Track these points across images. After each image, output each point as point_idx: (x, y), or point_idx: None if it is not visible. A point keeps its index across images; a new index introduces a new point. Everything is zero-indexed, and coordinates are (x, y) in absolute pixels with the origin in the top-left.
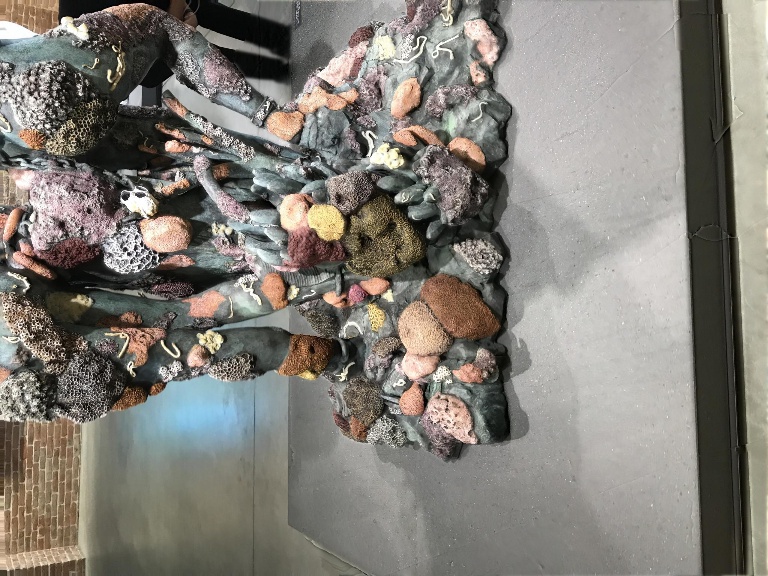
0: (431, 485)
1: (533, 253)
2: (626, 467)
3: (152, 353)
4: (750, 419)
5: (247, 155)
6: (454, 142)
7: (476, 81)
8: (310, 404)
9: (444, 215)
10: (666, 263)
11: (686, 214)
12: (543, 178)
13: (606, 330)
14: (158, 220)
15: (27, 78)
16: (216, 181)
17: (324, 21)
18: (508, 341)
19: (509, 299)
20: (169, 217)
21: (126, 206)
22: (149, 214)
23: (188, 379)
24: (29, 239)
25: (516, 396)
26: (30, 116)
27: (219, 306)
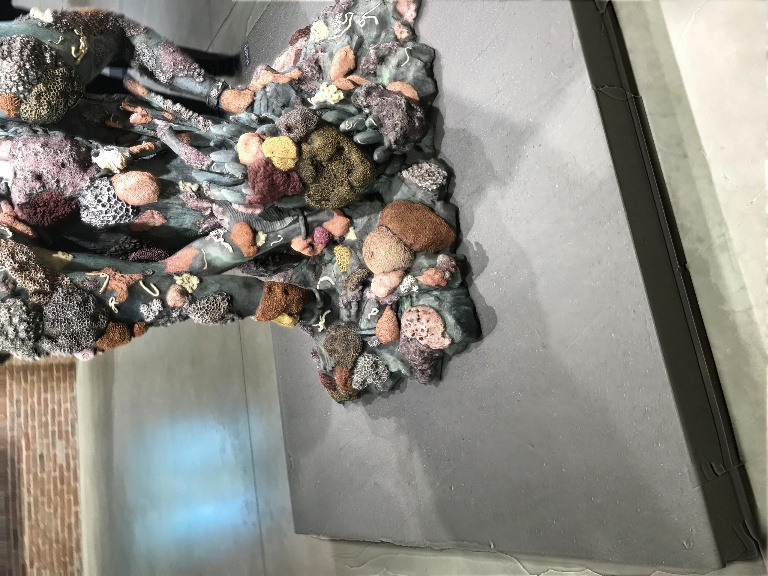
0: (421, 419)
1: (473, 162)
2: (584, 311)
3: (132, 291)
4: (685, 244)
5: (206, 126)
6: (389, 87)
7: (401, 38)
8: (300, 398)
9: (387, 138)
10: (580, 118)
11: (587, 71)
12: (470, 96)
13: (544, 199)
14: (128, 173)
15: None
16: None
17: (270, 51)
18: (465, 249)
19: (460, 212)
20: (138, 171)
21: (97, 165)
22: (119, 167)
23: (169, 322)
24: (10, 201)
25: (481, 295)
26: (4, 77)
27: (193, 259)
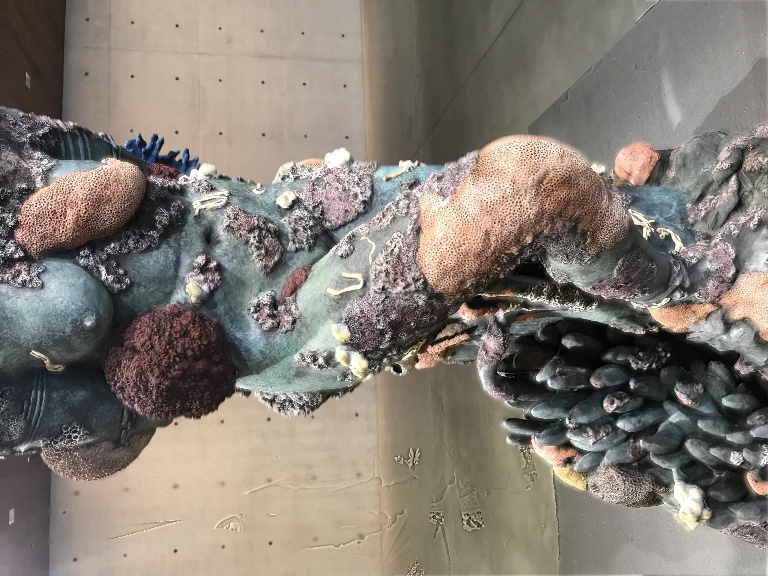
0: None
1: None
2: None
3: None
4: None
5: None
6: None
7: None
8: (599, 125)
9: None
10: None
11: None
12: None
13: None
14: None
15: (270, 403)
16: (495, 374)
17: None
18: None
19: None
20: (428, 356)
21: None
22: None
23: None
24: None
25: None
26: None
27: None
